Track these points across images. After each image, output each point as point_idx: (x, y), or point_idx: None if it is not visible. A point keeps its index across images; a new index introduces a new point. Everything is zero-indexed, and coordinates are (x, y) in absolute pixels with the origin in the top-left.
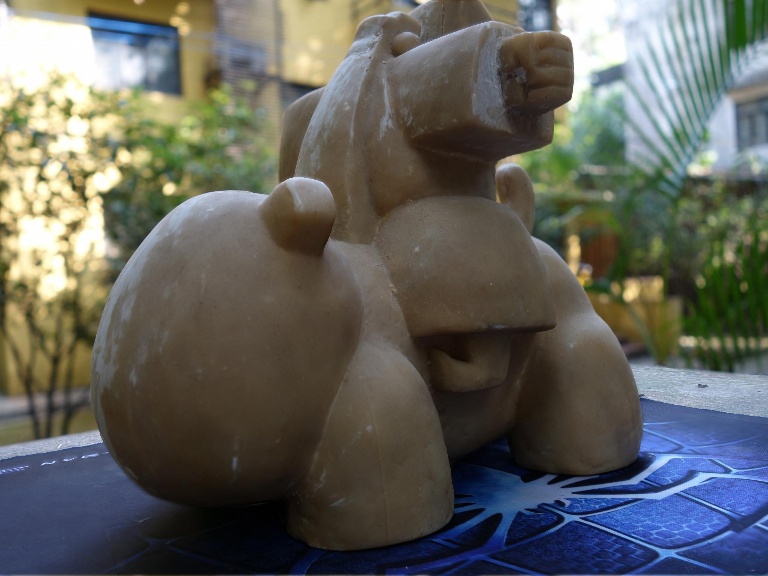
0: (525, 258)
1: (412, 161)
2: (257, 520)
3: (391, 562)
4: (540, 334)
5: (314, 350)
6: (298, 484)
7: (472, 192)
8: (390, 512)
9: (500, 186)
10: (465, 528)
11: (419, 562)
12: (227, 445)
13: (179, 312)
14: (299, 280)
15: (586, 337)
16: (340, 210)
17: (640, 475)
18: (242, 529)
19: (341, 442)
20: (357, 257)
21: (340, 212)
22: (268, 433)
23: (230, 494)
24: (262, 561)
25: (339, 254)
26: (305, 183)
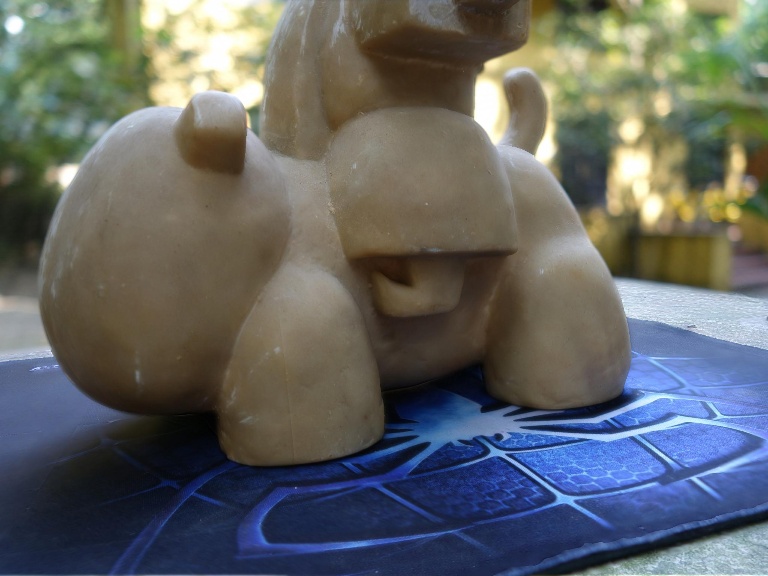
0: (475, 175)
1: (362, 69)
2: (197, 429)
3: (286, 481)
4: (511, 258)
5: (221, 270)
6: (214, 399)
7: (434, 102)
8: (295, 433)
9: (507, 94)
10: (383, 454)
11: (311, 484)
12: (129, 359)
13: (88, 229)
14: (207, 198)
15: (560, 263)
16: (289, 124)
17: (609, 414)
18: (185, 437)
19: (249, 362)
20: (298, 174)
21: (289, 126)
22: (168, 349)
23: (143, 404)
24: (177, 468)
25: (269, 171)
26: (211, 97)
